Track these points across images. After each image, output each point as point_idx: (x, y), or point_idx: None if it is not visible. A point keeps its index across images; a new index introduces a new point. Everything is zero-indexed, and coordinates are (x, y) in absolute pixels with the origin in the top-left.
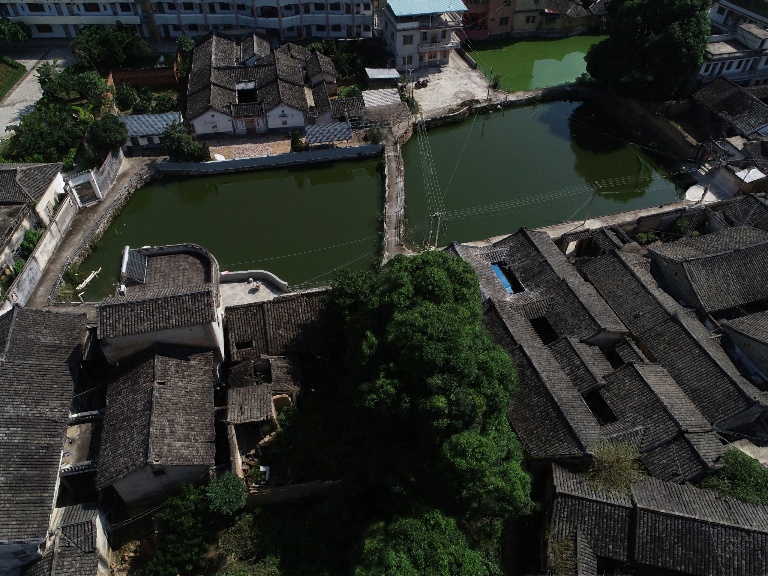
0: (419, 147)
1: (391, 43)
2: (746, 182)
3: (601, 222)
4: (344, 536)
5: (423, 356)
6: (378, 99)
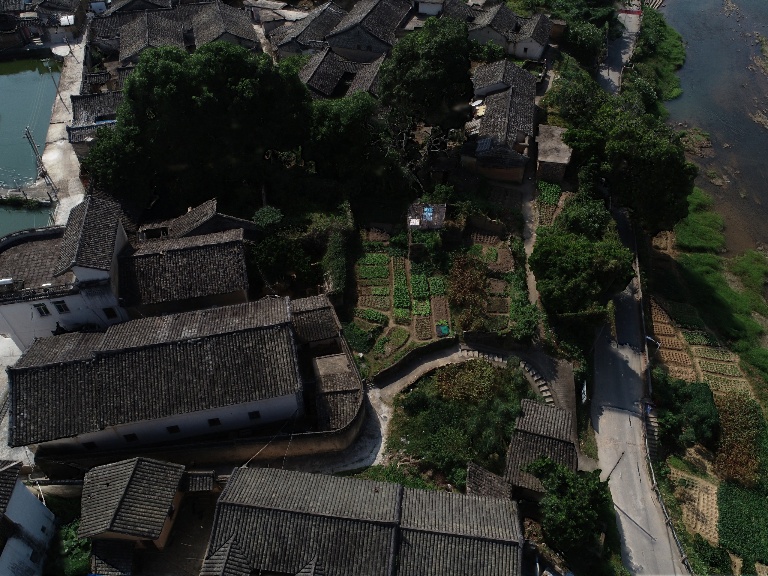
0: None
1: None
2: (73, 24)
3: (64, 91)
4: (301, 184)
5: (236, 54)
6: None
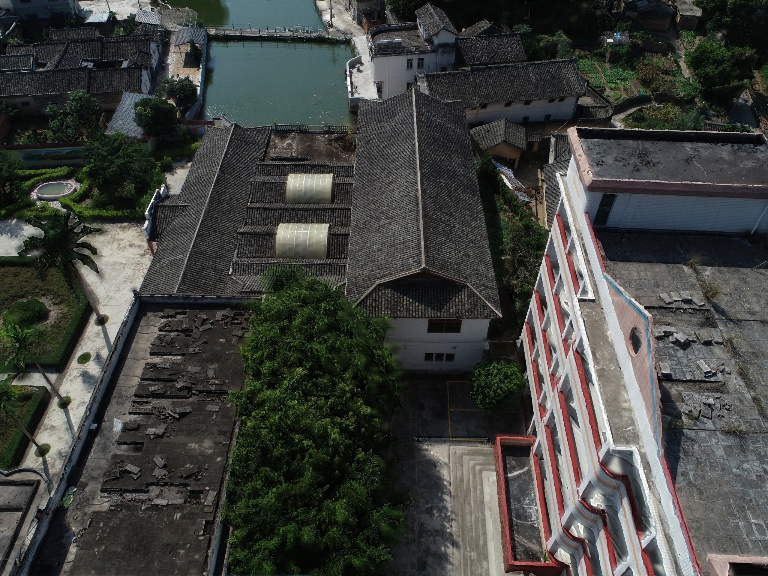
0: (240, 1)
1: (52, 5)
2: None
3: None
4: None
5: None
6: (149, 18)
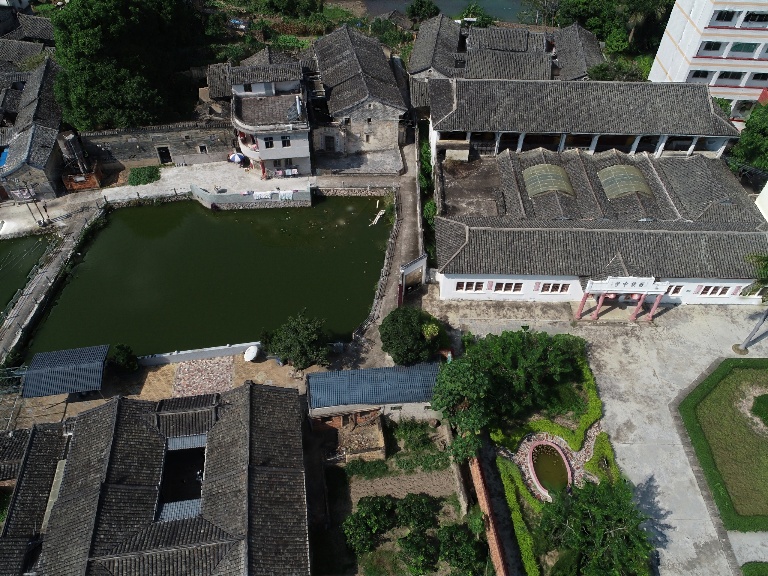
0: None
1: None
2: None
3: None
4: None
5: None
6: None
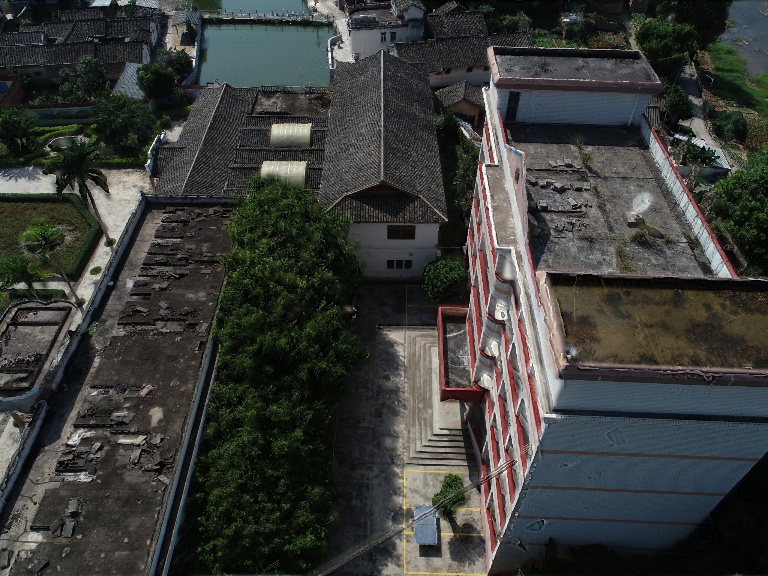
0: None
1: None
2: None
3: None
4: (492, 4)
5: None
6: (148, 3)
